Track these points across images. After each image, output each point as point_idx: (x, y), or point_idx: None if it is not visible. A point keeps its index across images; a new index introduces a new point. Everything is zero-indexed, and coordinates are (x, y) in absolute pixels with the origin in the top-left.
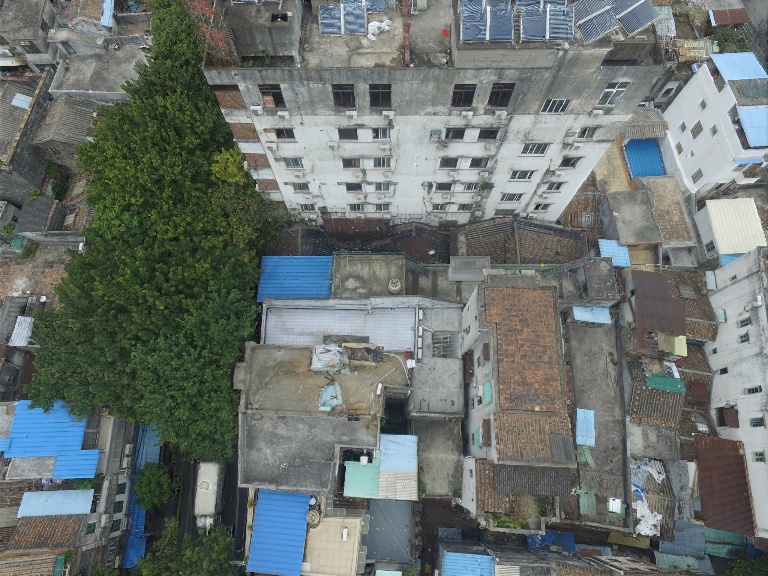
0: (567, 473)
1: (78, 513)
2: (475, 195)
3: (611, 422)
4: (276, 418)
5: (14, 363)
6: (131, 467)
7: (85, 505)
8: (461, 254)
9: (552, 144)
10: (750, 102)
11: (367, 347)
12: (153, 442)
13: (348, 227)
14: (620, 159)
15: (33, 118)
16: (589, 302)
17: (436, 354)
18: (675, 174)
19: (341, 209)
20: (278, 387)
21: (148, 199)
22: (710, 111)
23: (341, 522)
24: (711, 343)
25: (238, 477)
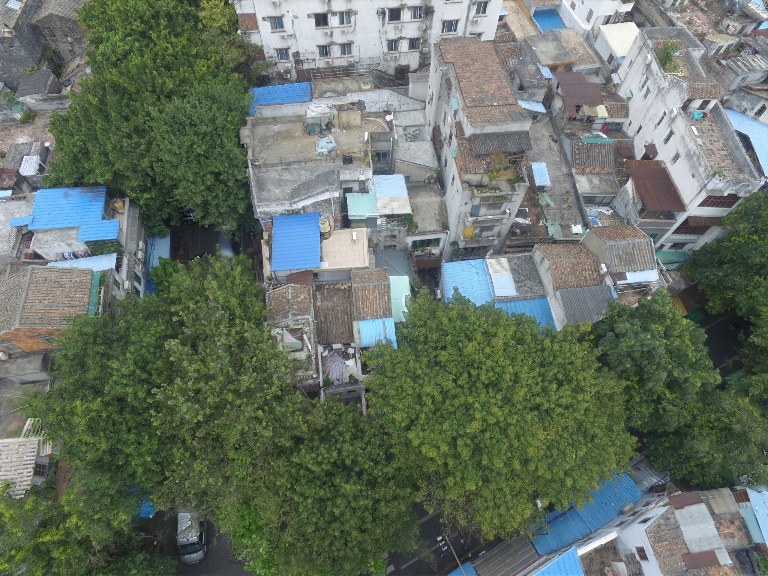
0: (527, 135)
1: (103, 270)
2: (421, 24)
3: (561, 176)
4: (280, 170)
5: (23, 191)
6: (144, 267)
7: (109, 264)
8: None
9: None
10: None
11: (351, 102)
12: (162, 252)
13: None
14: (531, 26)
15: (31, 3)
16: (525, 92)
17: (409, 141)
18: (574, 26)
19: (312, 53)
20: (279, 147)
21: (146, 32)
22: None
23: (349, 231)
24: (626, 120)
25: (254, 199)
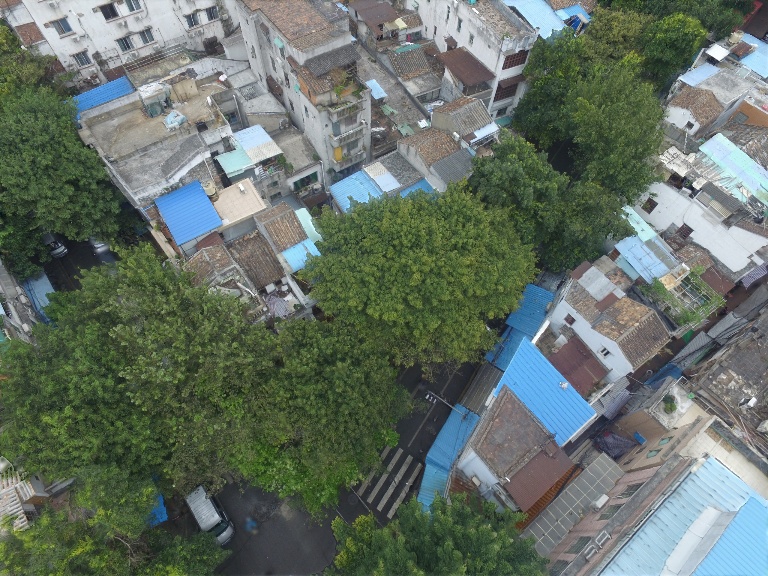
0: (352, 48)
1: None
2: None
3: (392, 87)
4: (139, 158)
5: None
6: (33, 312)
7: None
8: None
9: None
10: None
11: (180, 73)
12: (45, 292)
13: None
14: None
15: None
16: None
17: None
18: None
19: (113, 50)
20: (127, 138)
21: None
22: None
23: (234, 186)
24: (422, 28)
25: (128, 188)
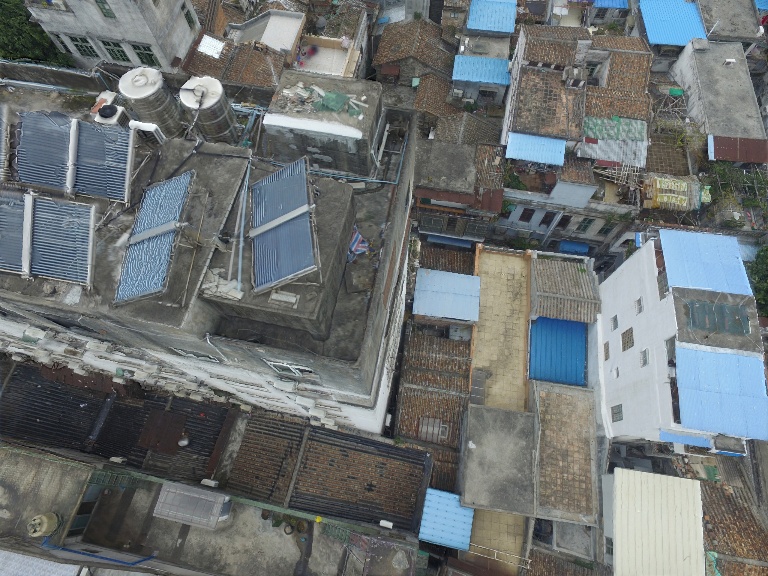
0: None
1: None
2: None
3: None
4: None
5: None
6: None
7: None
8: (229, 452)
9: (263, 386)
10: (702, 339)
11: None
12: None
13: (73, 379)
14: (523, 339)
15: None
16: None
17: None
18: (595, 389)
19: None
20: None
21: None
22: (645, 322)
23: None
24: None
25: None
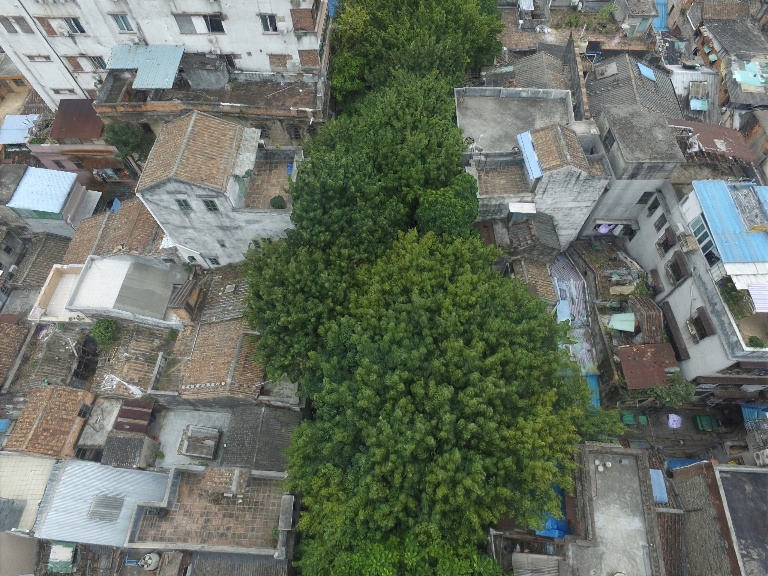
0: None
1: None
2: None
3: None
4: None
5: None
6: None
7: None
8: None
9: None
10: None
11: None
12: None
13: None
14: None
15: None
16: None
17: None
18: None
19: None
20: None
21: None
22: None
23: None
24: None
25: None
